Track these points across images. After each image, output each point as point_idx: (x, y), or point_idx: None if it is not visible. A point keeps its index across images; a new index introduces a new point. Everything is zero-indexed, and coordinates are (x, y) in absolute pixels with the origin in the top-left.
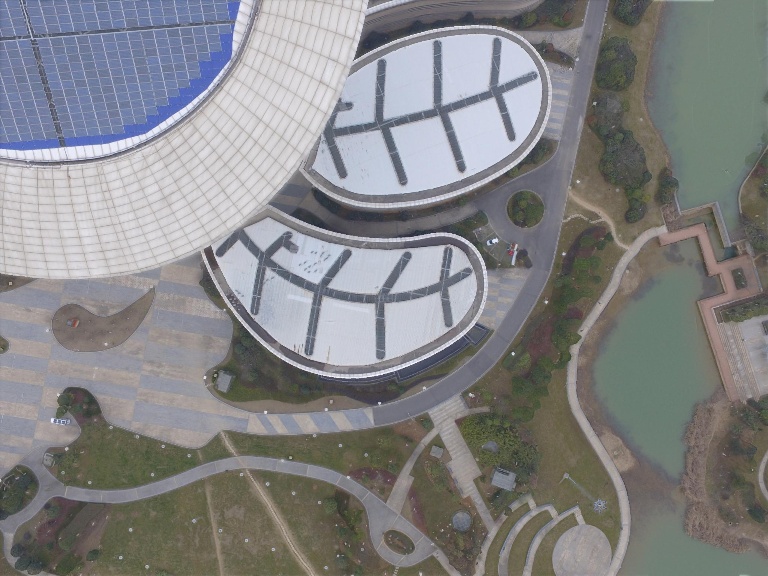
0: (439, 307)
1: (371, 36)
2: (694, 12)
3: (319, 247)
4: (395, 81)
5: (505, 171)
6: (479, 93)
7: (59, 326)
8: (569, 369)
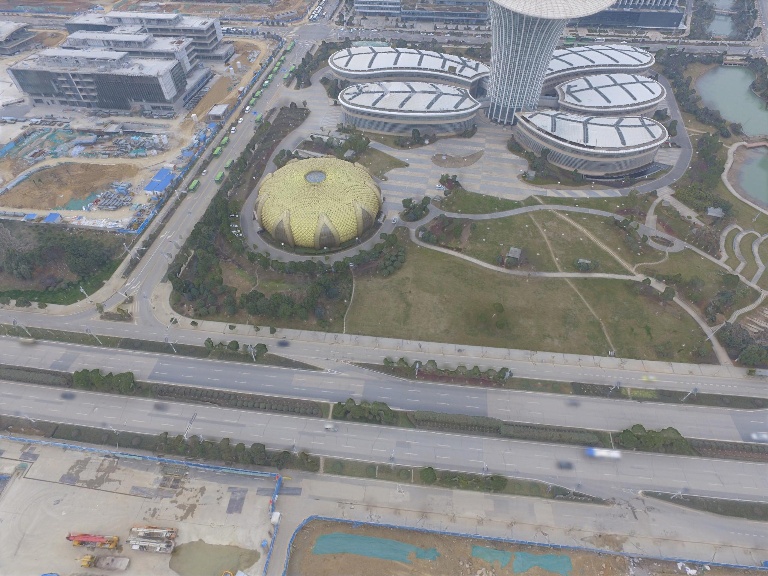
0: (646, 131)
1: None
2: (712, 90)
3: None
4: None
5: (655, 103)
6: None
7: None
8: (726, 184)
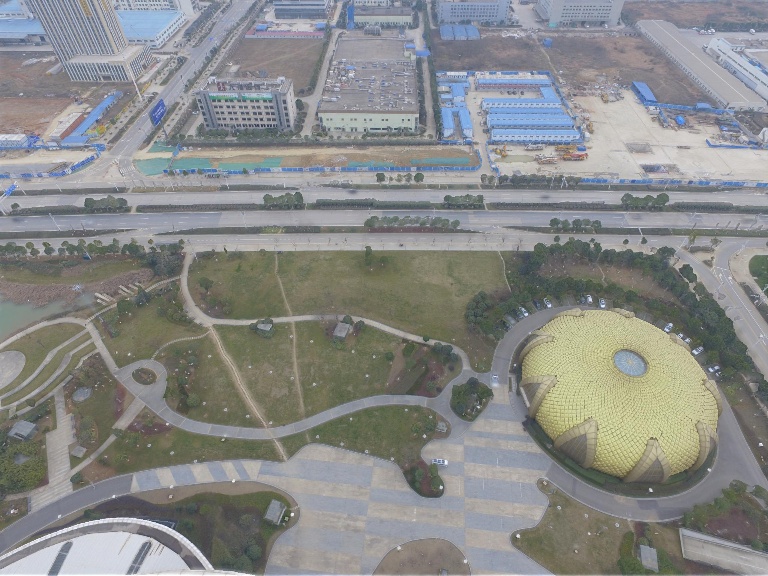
0: None
1: None
2: None
3: None
4: None
5: None
6: None
7: (461, 569)
8: None
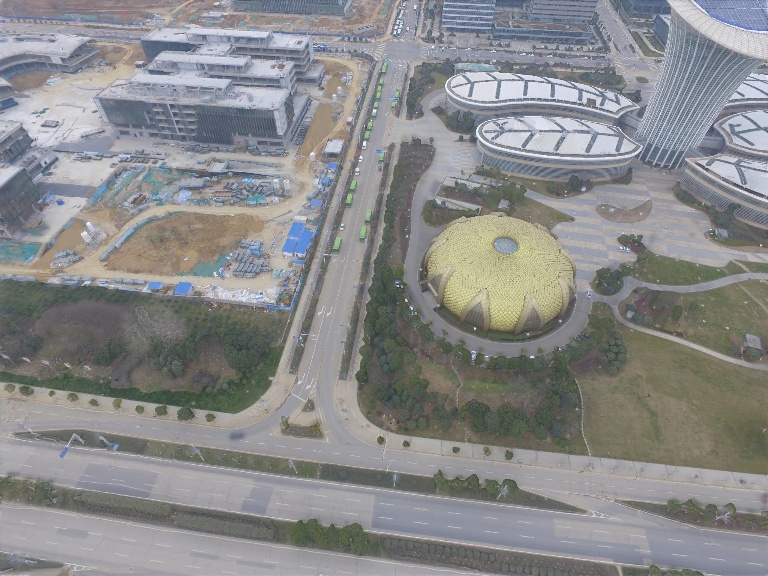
0: None
1: (712, 124)
2: None
3: None
4: (757, 118)
5: None
6: None
7: None
8: None
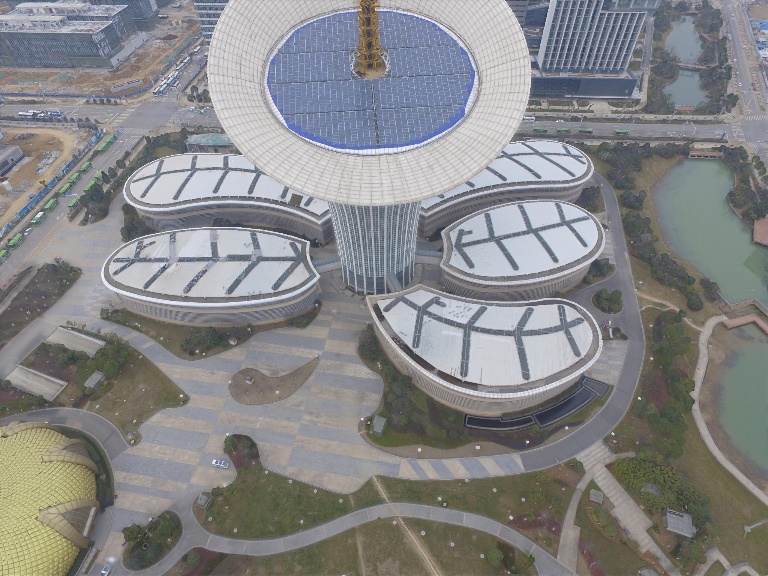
0: (566, 341)
1: None
2: (675, 206)
3: (462, 305)
4: (498, 220)
5: (586, 264)
6: (555, 223)
7: (236, 384)
8: (697, 423)
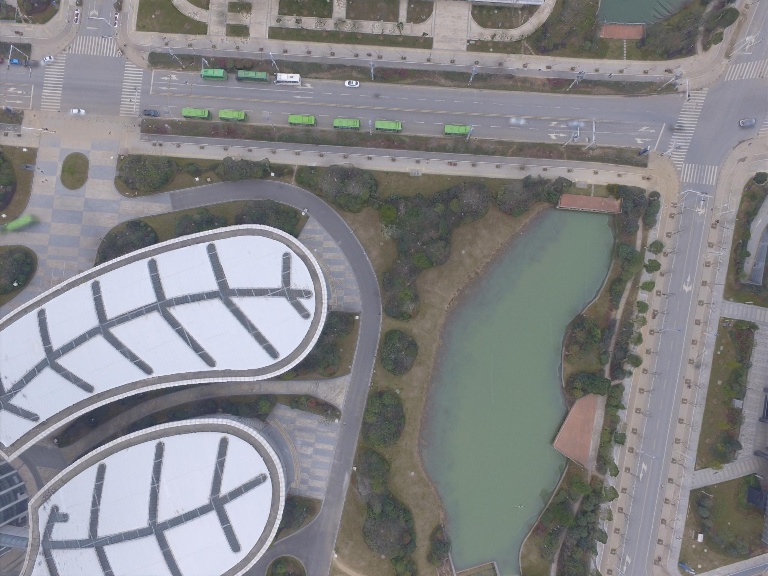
0: None
1: None
2: (473, 350)
3: None
4: (111, 493)
5: None
6: (198, 507)
7: None
8: None
